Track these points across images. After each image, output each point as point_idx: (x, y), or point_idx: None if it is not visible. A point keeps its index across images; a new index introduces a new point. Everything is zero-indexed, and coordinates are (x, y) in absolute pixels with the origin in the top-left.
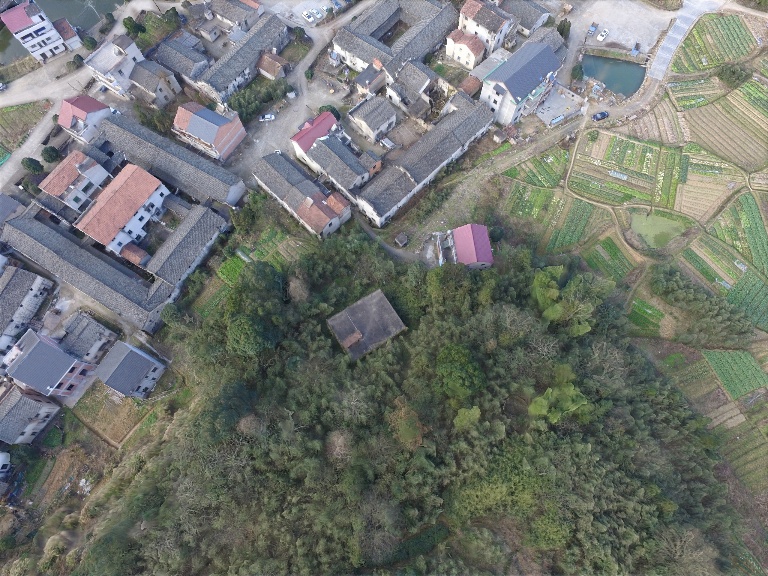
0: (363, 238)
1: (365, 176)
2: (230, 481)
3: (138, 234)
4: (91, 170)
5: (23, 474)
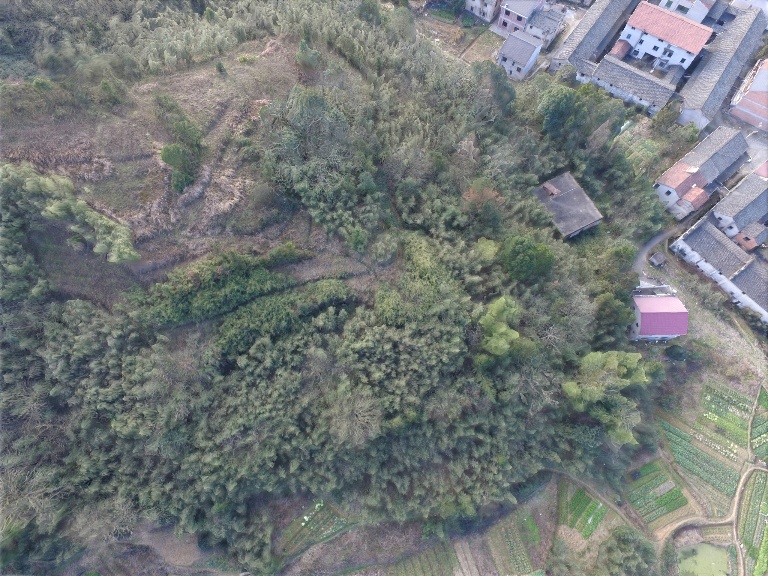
0: (656, 217)
1: (733, 230)
2: (445, 78)
3: (639, 51)
4: (702, 6)
5: (445, 8)
